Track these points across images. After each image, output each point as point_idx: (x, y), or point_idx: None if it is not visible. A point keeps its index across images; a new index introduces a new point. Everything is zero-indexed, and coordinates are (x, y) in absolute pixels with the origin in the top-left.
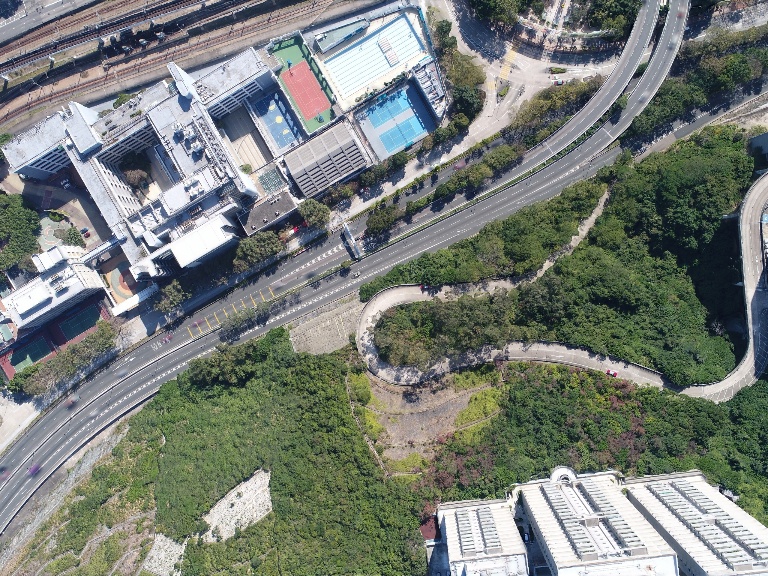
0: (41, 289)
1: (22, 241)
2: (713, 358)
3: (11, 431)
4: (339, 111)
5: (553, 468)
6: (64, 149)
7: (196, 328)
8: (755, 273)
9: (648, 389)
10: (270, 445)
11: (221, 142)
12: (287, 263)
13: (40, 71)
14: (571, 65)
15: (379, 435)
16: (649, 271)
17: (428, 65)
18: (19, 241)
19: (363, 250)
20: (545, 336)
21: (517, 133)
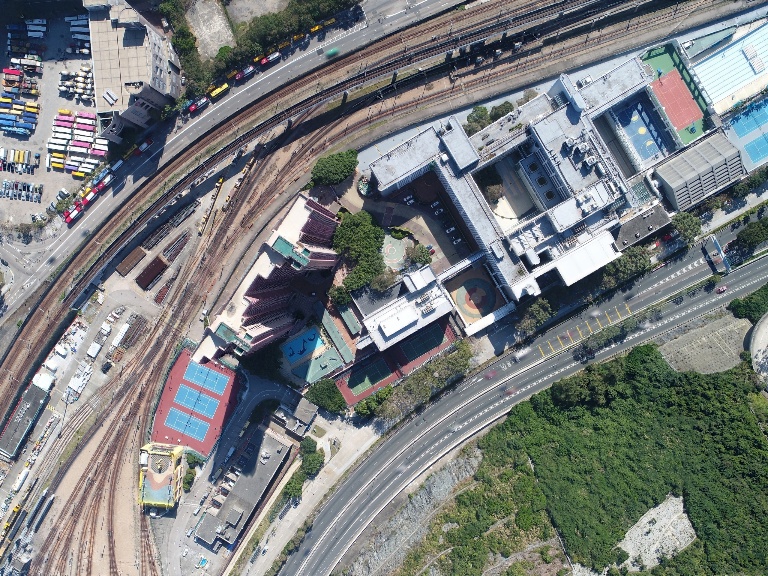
0: (410, 310)
1: (372, 260)
2: None
3: (349, 456)
4: (718, 121)
5: None
6: (433, 165)
7: (548, 347)
8: None
9: None
10: (677, 469)
11: (611, 156)
12: (644, 278)
13: (382, 84)
14: None
15: None
16: None
17: None
18: (370, 260)
19: None
20: None
21: None
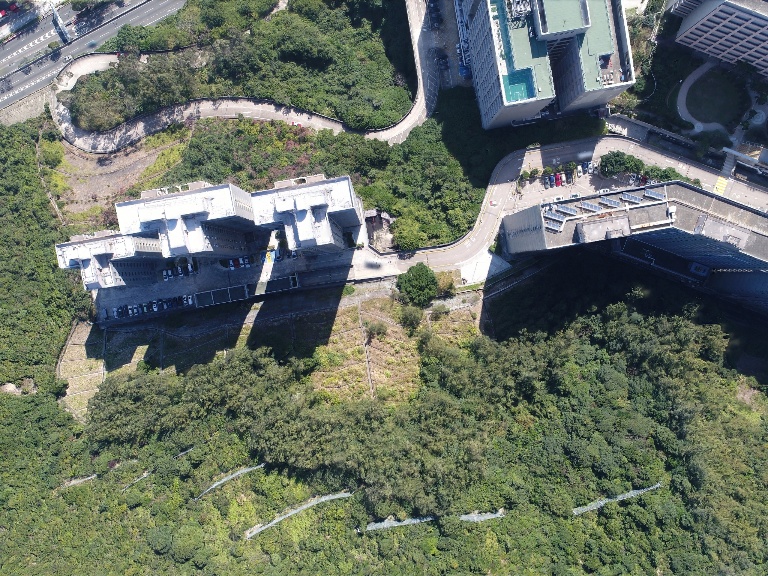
0: None
1: None
2: (390, 104)
3: None
4: None
5: None
6: None
7: None
8: (419, 13)
9: (321, 130)
10: None
11: None
12: None
13: None
14: None
15: (63, 192)
16: (347, 38)
17: None
18: None
19: (76, 35)
20: (231, 91)
21: None
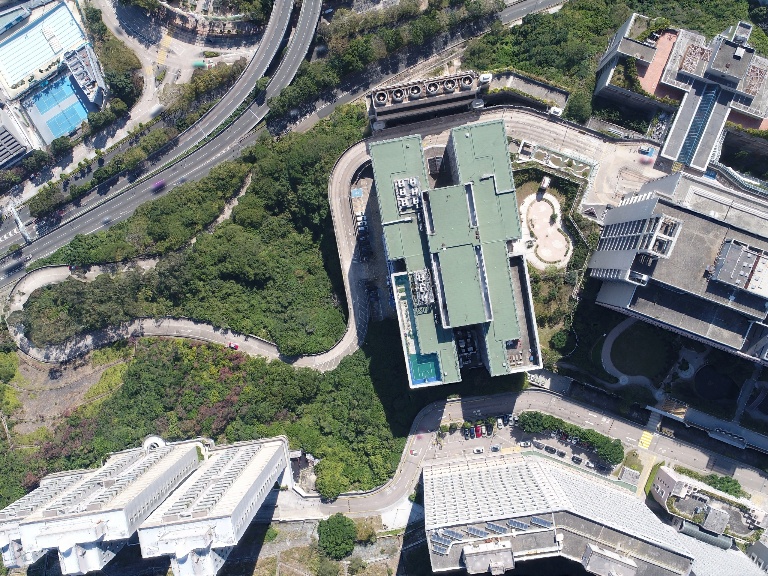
0: None
1: None
2: (323, 329)
3: None
4: None
5: (144, 437)
6: None
7: None
8: (349, 246)
9: (253, 360)
10: None
11: None
12: None
13: None
14: (224, 49)
15: (14, 411)
16: (289, 247)
17: (79, 51)
18: None
19: (37, 234)
20: (172, 312)
21: (176, 116)
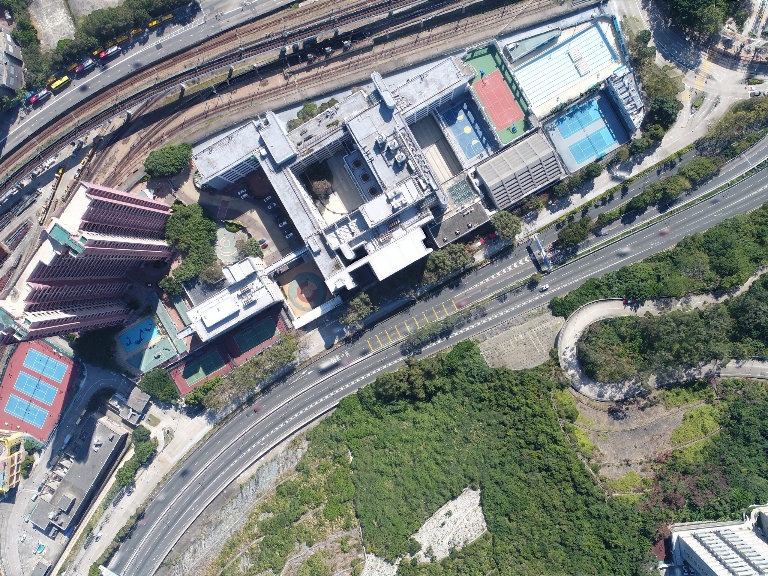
0: (230, 302)
1: (202, 252)
2: None
3: (182, 445)
4: (536, 122)
5: None
6: (255, 159)
7: (376, 341)
8: None
9: None
10: (477, 463)
11: None
12: (471, 275)
13: (218, 79)
14: None
15: (592, 453)
16: None
17: (626, 75)
18: (199, 252)
19: (550, 263)
20: (762, 353)
21: (711, 145)
